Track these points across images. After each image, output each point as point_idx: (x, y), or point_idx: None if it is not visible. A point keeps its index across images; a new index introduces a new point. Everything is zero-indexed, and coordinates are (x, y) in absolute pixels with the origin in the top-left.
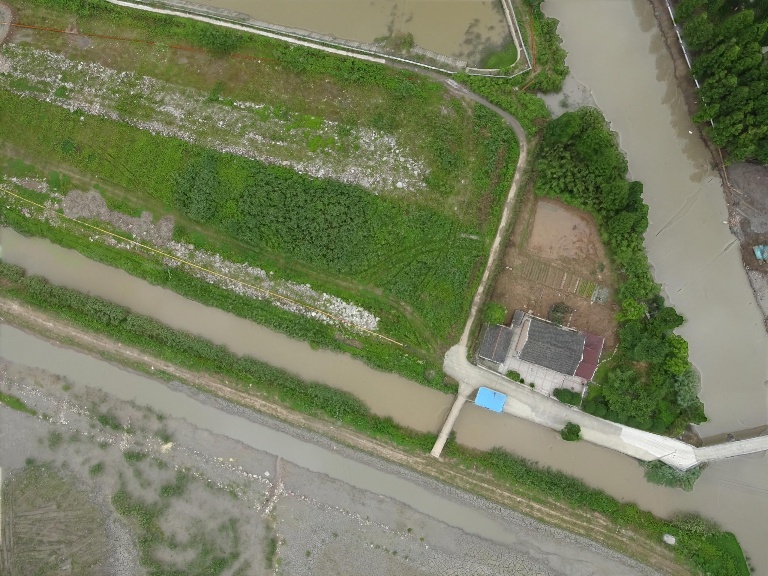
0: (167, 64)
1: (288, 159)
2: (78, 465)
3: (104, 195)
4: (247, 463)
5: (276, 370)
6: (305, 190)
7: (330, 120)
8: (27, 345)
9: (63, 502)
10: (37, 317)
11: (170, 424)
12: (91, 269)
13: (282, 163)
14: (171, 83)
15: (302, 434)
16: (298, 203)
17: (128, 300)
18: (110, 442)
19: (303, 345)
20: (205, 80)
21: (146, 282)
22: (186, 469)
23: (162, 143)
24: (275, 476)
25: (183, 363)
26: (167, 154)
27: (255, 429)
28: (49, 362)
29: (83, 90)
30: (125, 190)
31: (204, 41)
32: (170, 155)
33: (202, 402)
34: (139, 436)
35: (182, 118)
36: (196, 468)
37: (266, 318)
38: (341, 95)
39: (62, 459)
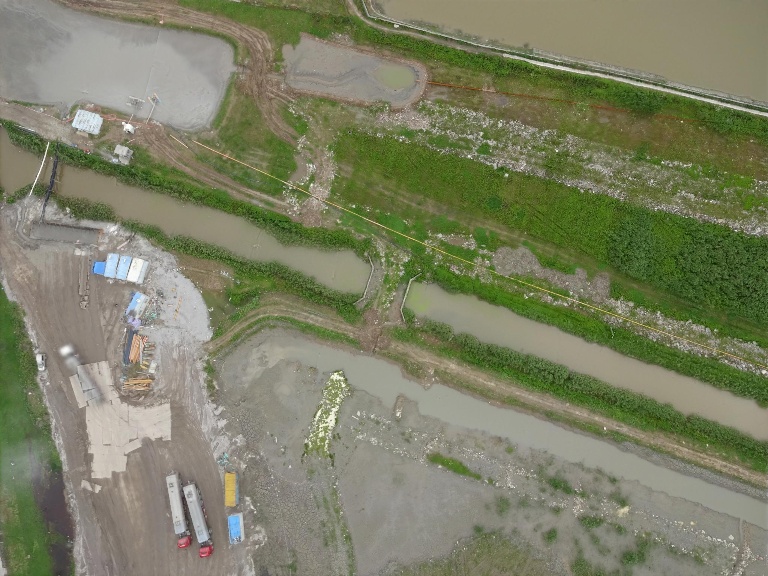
0: (589, 123)
1: (723, 217)
2: (529, 532)
3: (535, 252)
4: (709, 526)
5: (729, 429)
6: (745, 248)
7: (759, 179)
8: (463, 406)
9: (520, 572)
10: (477, 377)
11: (623, 487)
12: (523, 326)
13: (717, 221)
14: (595, 141)
15: (765, 495)
16: (741, 261)
17: (564, 358)
18: (562, 507)
19: (750, 403)
20: (629, 139)
21: (581, 340)
22: (646, 534)
23: (592, 200)
24: (739, 540)
25: (637, 423)
26: (599, 211)
27: (712, 491)
28: (489, 423)
29: (508, 147)
30: (556, 247)
31: (628, 101)
32: (602, 212)
33: (656, 463)
34: (593, 500)
35: (611, 176)
36: (657, 533)
37: (716, 376)
38: (767, 155)
39: (511, 526)
